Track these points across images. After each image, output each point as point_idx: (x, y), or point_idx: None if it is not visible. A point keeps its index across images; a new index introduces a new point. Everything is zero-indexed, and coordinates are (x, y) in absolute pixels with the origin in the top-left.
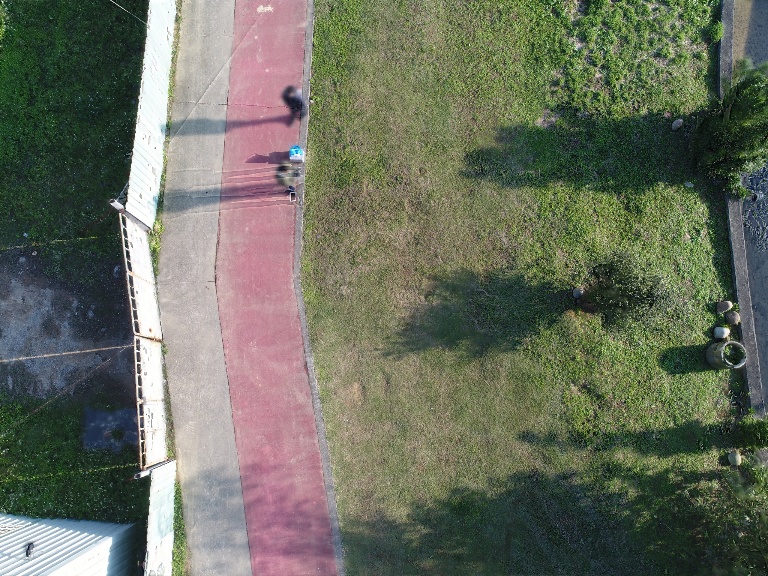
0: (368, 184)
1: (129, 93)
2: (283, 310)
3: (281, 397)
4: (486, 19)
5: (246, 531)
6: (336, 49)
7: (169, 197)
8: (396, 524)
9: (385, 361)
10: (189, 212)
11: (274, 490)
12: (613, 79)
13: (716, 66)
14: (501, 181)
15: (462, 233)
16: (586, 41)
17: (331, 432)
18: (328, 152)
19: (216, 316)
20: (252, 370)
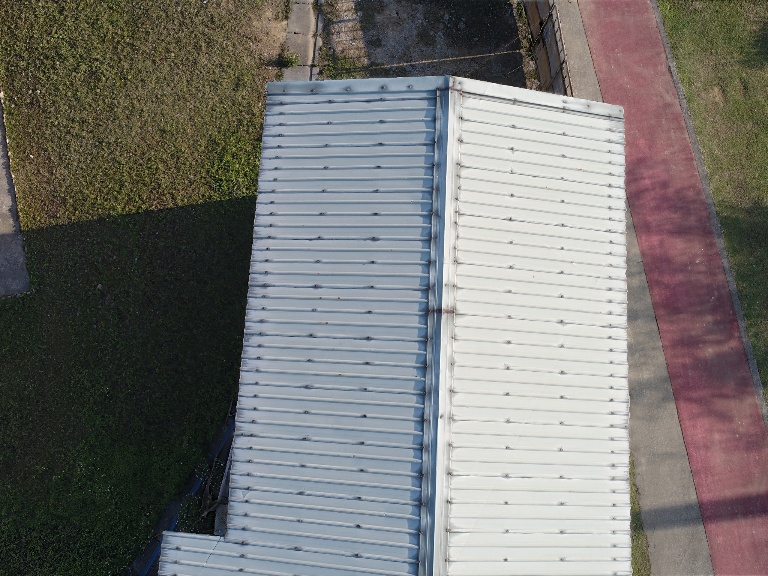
0: None
1: None
2: (643, 21)
3: (650, 97)
4: None
5: (630, 213)
6: None
7: None
8: (767, 210)
9: (741, 68)
10: None
11: (652, 178)
12: None
13: None
14: None
15: None
16: None
17: (699, 129)
18: None
19: (580, 26)
20: (620, 73)
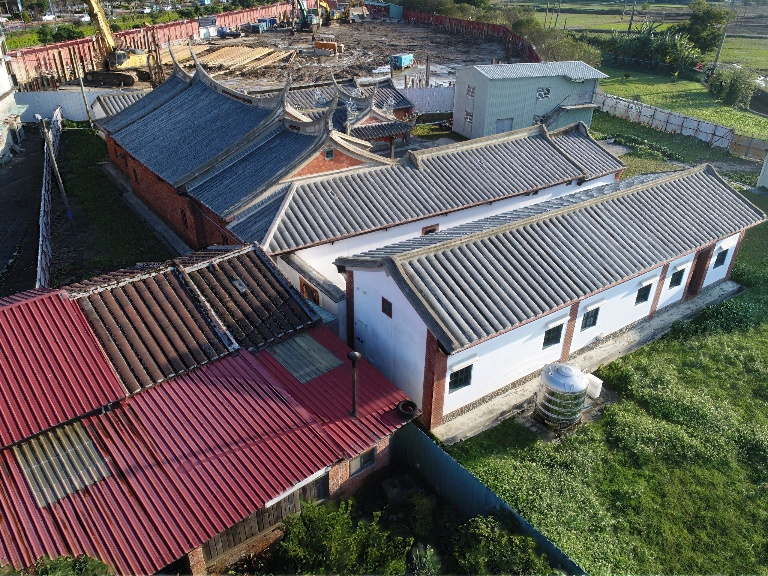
0: None
1: None
2: None
3: None
4: None
5: None
6: None
7: None
8: None
9: None
10: None
11: None
12: None
13: None
14: None
15: None
16: (767, 127)
17: None
18: None
19: None
20: None
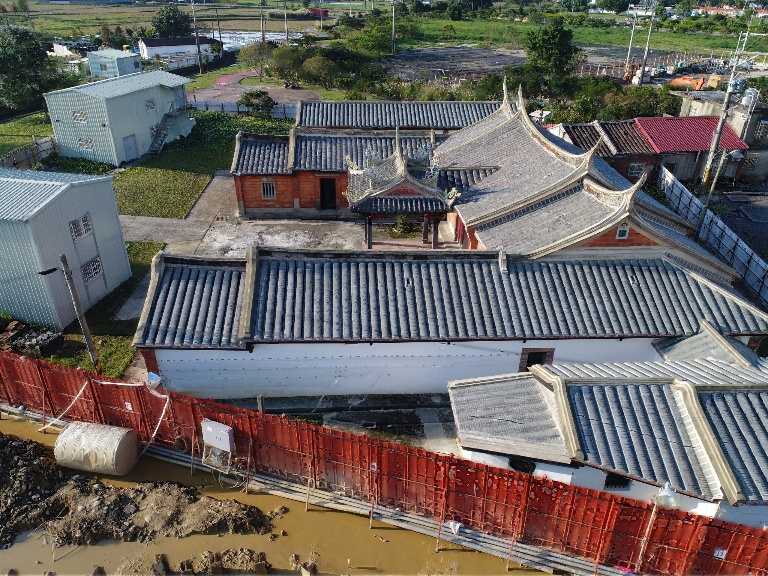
0: None
1: None
2: None
3: None
4: None
5: None
6: None
7: None
8: None
9: None
10: None
11: None
12: None
13: None
14: None
15: None
16: None
17: None
18: None
19: None
20: None
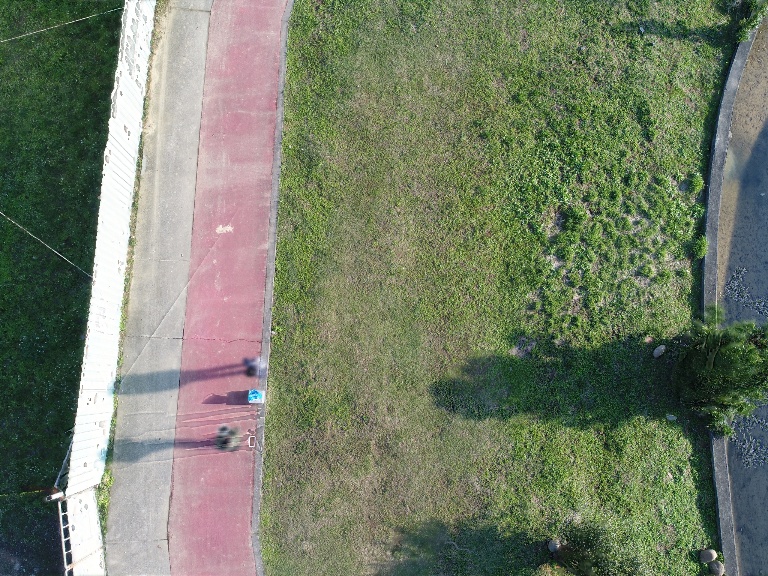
0: (332, 425)
1: (78, 328)
2: (240, 571)
3: None
4: (459, 236)
5: None
6: (300, 273)
7: (119, 444)
8: None
9: None
10: (141, 461)
11: None
12: (592, 302)
13: (700, 284)
14: (473, 419)
15: (432, 478)
16: (564, 260)
17: None
18: (290, 389)
19: None
20: None
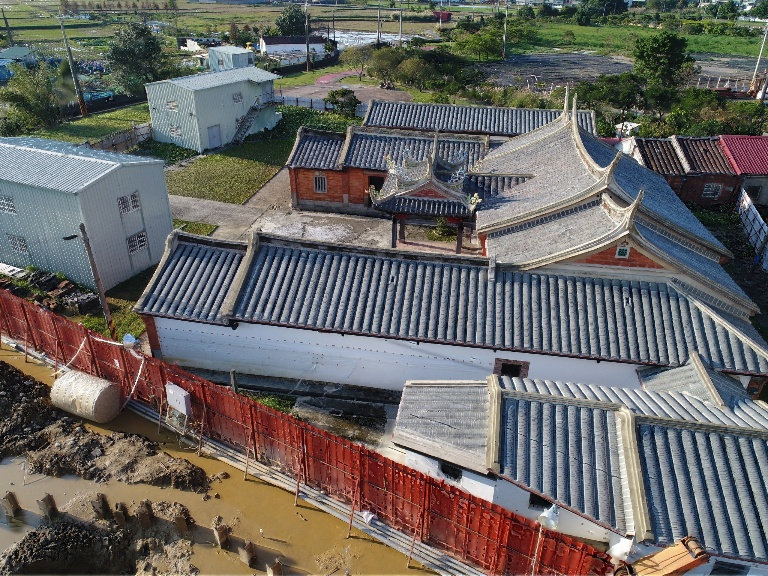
0: None
1: None
2: None
3: None
4: None
5: None
6: None
7: None
8: None
9: None
10: None
11: None
12: None
13: None
14: None
15: None
16: None
17: None
18: None
19: None
20: None
